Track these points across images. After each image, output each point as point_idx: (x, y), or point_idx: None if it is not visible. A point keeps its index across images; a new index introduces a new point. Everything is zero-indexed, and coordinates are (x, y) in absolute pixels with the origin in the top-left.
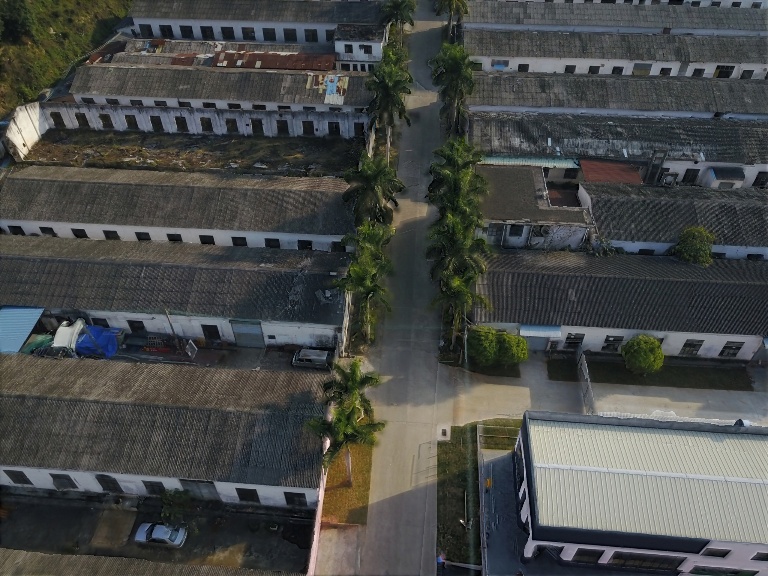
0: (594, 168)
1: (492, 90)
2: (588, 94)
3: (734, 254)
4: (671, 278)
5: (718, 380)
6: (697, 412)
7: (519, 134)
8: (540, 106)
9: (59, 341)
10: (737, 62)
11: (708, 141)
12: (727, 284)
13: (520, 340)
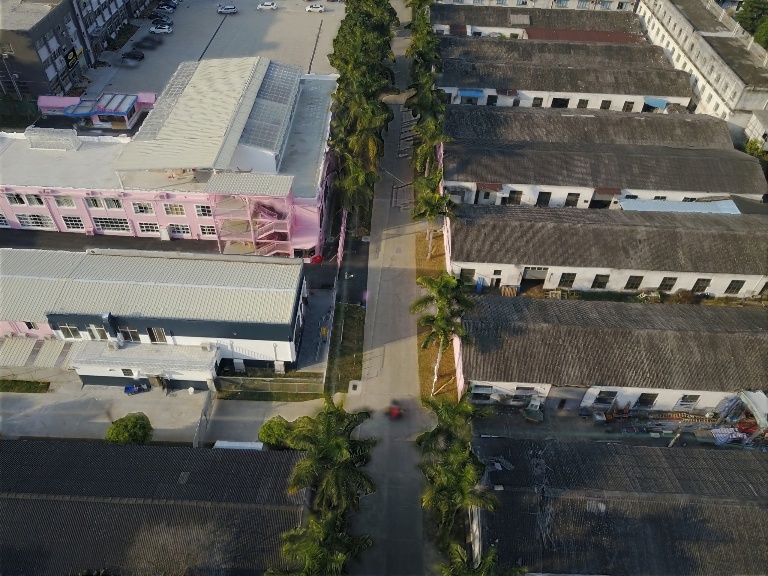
0: None
1: None
2: None
3: None
4: (35, 498)
5: None
6: (100, 412)
7: None
8: None
9: (759, 395)
10: None
11: None
12: None
13: (268, 425)
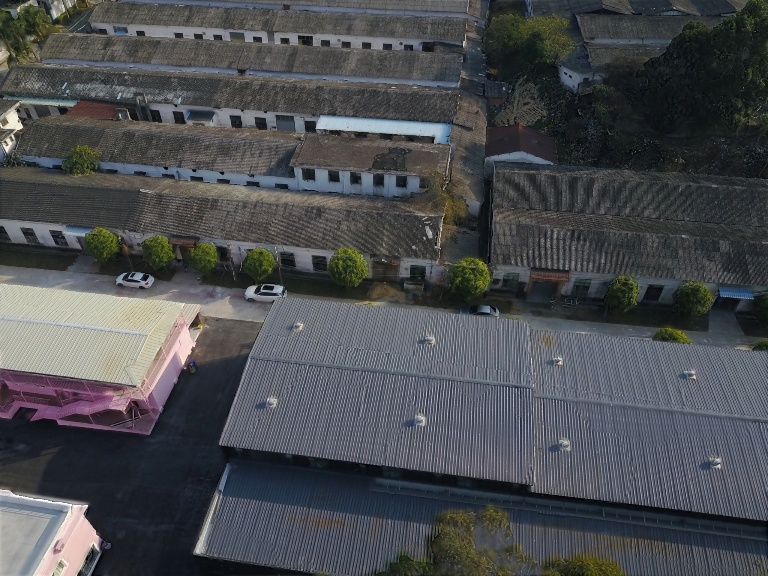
0: (84, 106)
1: (64, 46)
2: (139, 52)
3: (124, 171)
4: (25, 180)
5: (46, 262)
6: (2, 282)
7: (44, 79)
8: (96, 60)
9: None
10: (312, 33)
11: (192, 89)
12: (63, 186)
13: None
